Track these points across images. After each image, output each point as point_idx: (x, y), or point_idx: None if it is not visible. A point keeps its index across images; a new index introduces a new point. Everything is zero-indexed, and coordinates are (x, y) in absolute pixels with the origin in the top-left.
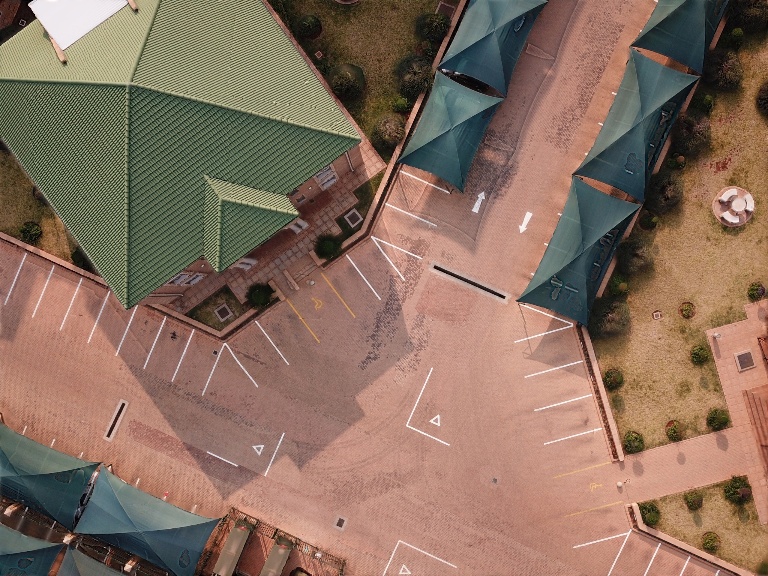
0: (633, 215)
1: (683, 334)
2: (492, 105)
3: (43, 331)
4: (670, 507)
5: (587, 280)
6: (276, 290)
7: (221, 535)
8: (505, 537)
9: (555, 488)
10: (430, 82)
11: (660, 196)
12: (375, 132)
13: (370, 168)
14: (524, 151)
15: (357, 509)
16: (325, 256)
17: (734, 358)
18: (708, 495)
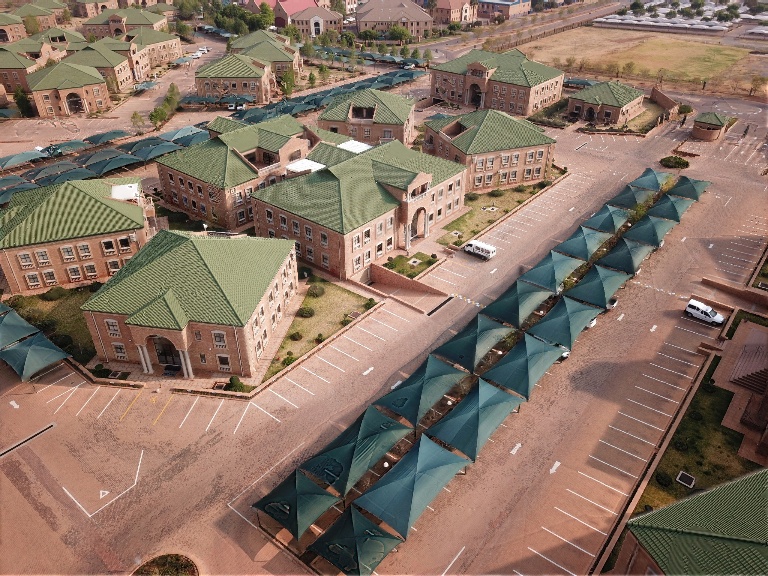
0: None
1: None
2: None
3: None
4: None
5: None
6: None
7: None
8: None
9: None
10: None
11: None
12: None
13: (7, 295)
14: None
15: None
16: None
17: None
18: None
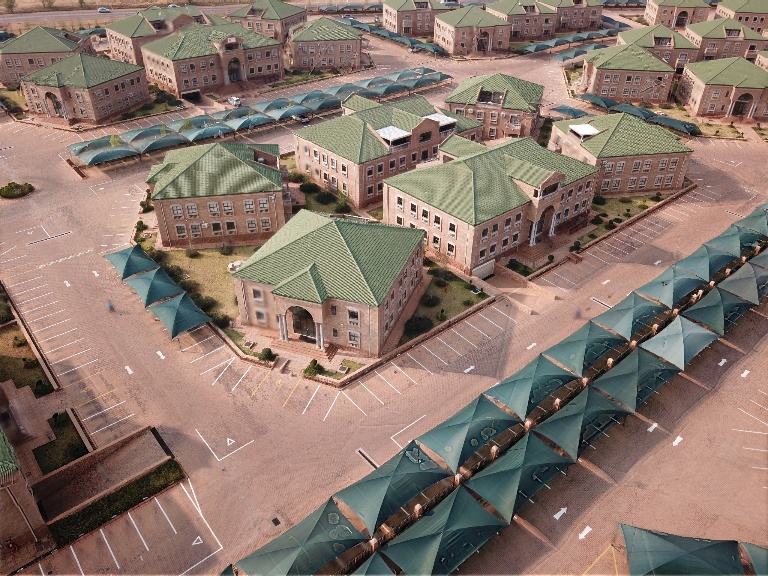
0: None
1: None
2: None
3: None
4: (764, 137)
5: None
6: None
7: None
8: None
9: None
10: None
11: None
12: None
13: None
14: None
15: None
16: None
17: None
18: (759, 132)
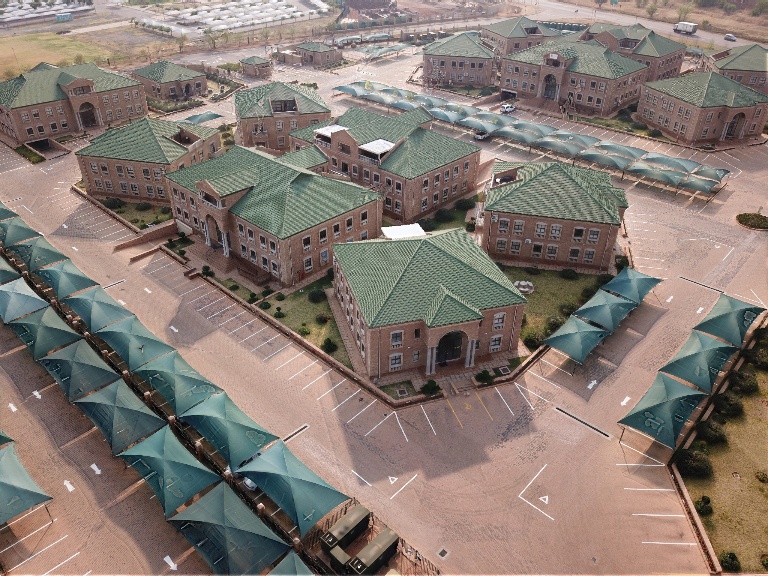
0: (704, 397)
1: (762, 492)
2: (604, 331)
3: (278, 377)
4: None
5: (672, 416)
6: (443, 389)
7: None
8: None
9: None
10: None
11: (725, 402)
12: (528, 336)
13: (521, 352)
14: (625, 369)
15: (461, 546)
16: (482, 380)
17: None
18: None
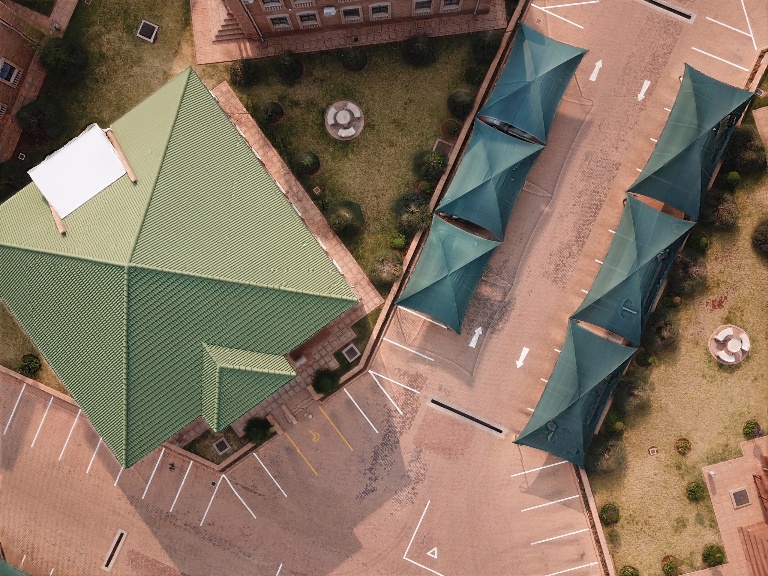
0: (629, 359)
1: (679, 470)
2: (489, 250)
3: (42, 461)
4: None
5: (583, 426)
6: (274, 425)
7: None
8: None
9: None
10: (427, 221)
11: (656, 336)
12: (373, 270)
13: (368, 303)
14: (521, 287)
15: None
16: (323, 392)
17: (729, 495)
18: None
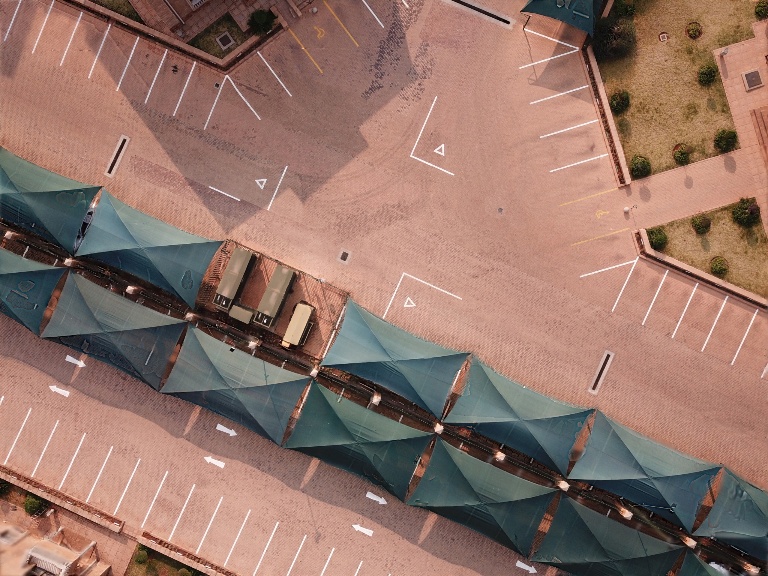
0: None
1: (690, 55)
2: None
3: (43, 67)
4: (677, 232)
5: None
6: (278, 15)
7: (224, 270)
8: (511, 267)
9: (561, 216)
10: None
11: None
12: None
13: None
14: None
15: (361, 242)
16: None
17: (742, 77)
18: (716, 219)
